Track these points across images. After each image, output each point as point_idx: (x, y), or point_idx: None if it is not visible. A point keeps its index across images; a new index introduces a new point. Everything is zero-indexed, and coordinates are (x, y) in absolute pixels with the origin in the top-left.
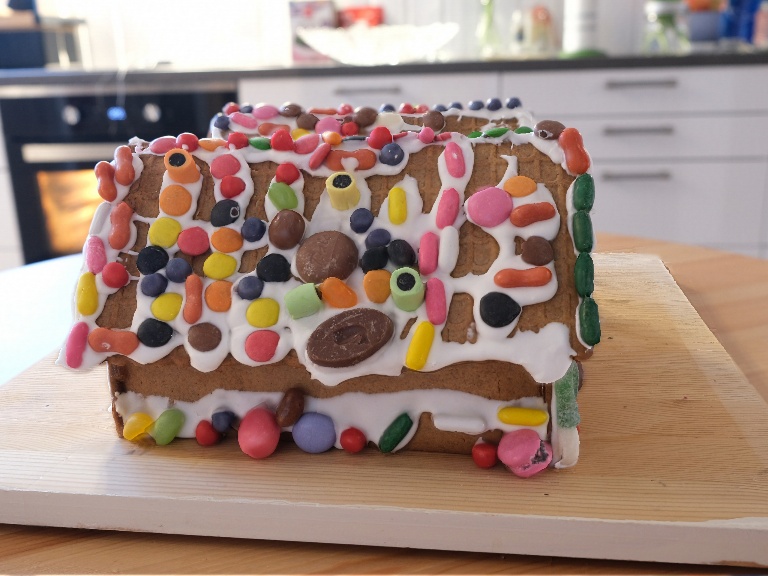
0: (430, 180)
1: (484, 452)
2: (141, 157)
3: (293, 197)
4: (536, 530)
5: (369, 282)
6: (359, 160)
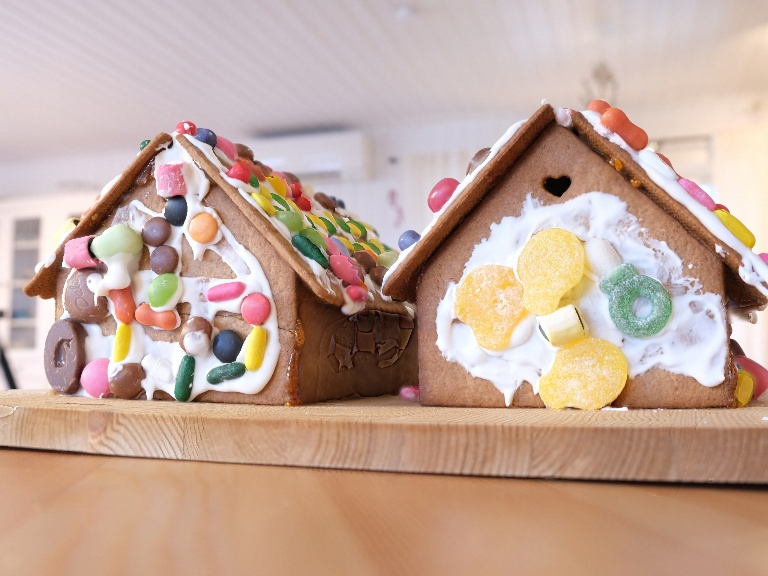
0: None
1: None
2: None
3: None
4: None
5: None
6: None
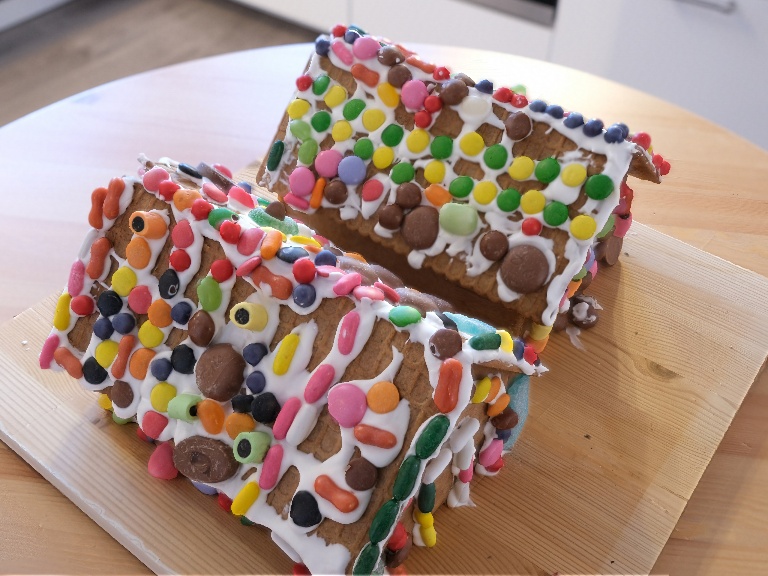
0: (328, 337)
1: (297, 575)
2: (135, 186)
3: (215, 300)
4: None
5: (229, 424)
6: (273, 291)
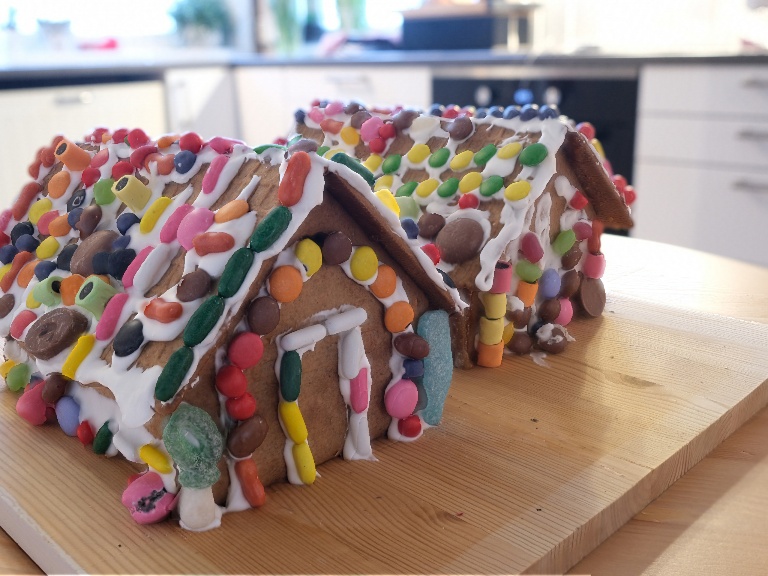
0: None
1: (130, 483)
2: (77, 144)
3: (108, 194)
4: (66, 573)
5: None
6: (158, 165)
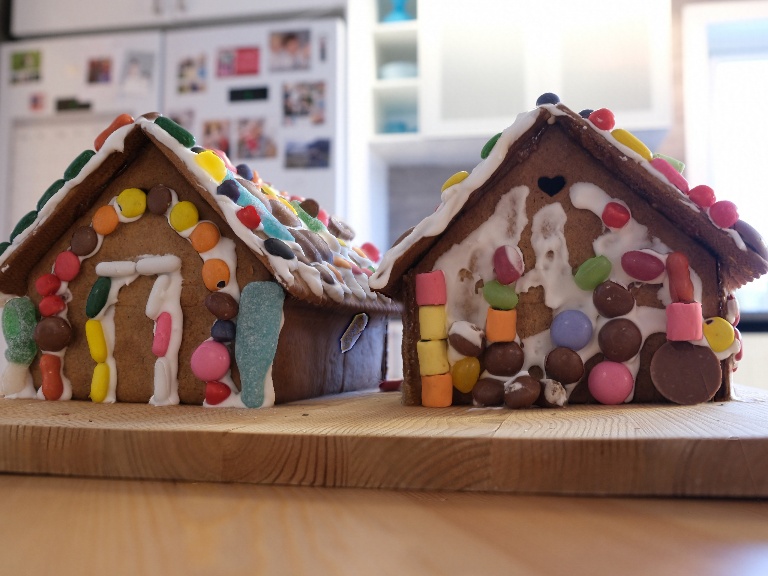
0: None
1: None
2: None
3: None
4: None
5: None
6: None
